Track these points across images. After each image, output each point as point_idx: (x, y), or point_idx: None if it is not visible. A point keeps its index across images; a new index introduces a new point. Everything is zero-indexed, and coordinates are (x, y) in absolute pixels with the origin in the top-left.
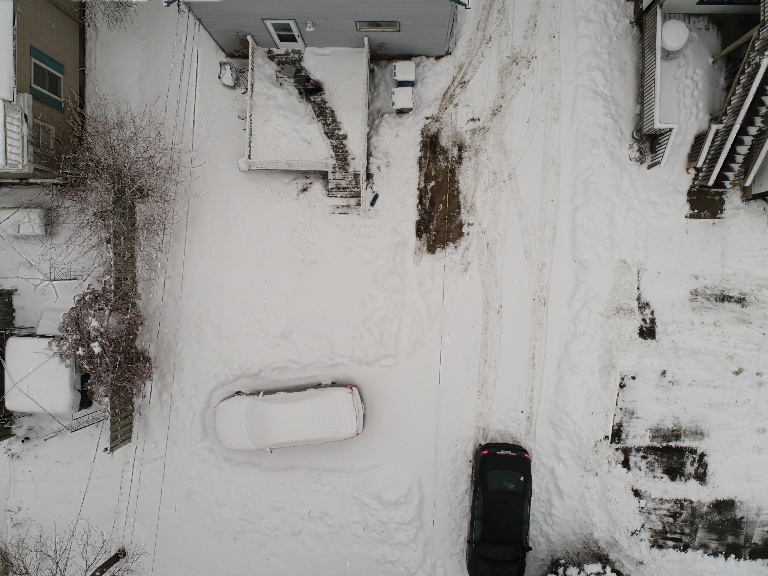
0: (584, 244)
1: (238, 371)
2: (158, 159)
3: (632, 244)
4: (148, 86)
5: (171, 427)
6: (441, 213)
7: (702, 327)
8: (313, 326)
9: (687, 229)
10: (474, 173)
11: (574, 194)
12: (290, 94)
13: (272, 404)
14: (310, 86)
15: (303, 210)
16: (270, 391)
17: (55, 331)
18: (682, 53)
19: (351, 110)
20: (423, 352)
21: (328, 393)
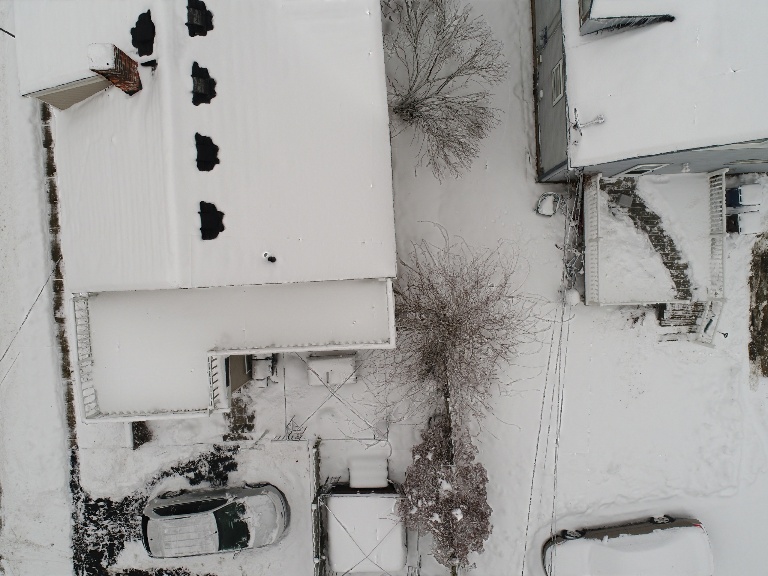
0: None
1: (564, 510)
2: (492, 304)
3: None
4: (450, 217)
5: (494, 571)
6: None
7: None
8: (643, 459)
9: None
10: None
11: None
12: (626, 225)
13: (626, 552)
14: (645, 215)
15: (629, 340)
16: (607, 532)
17: (372, 483)
18: None
19: (696, 240)
20: (764, 480)
21: (681, 535)
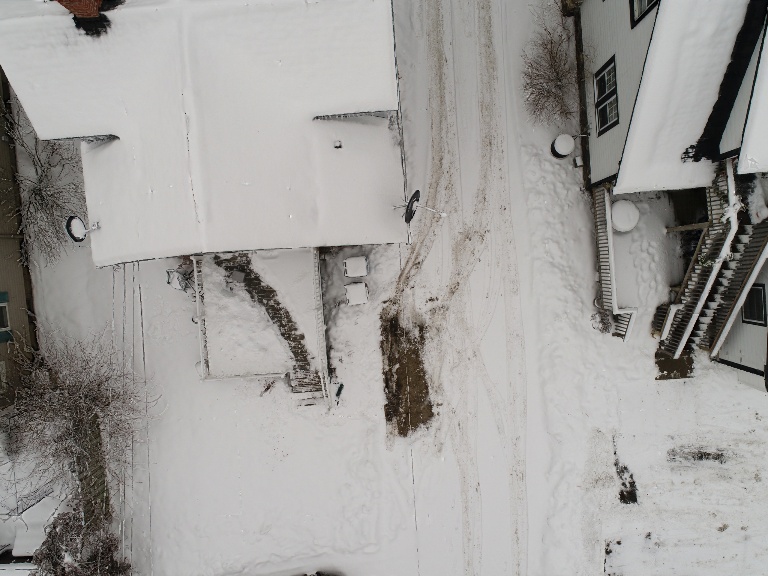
0: (556, 418)
1: (221, 570)
2: (114, 380)
3: (604, 412)
4: (97, 292)
5: None
6: (409, 395)
7: (683, 487)
8: (292, 519)
9: (658, 390)
10: (438, 353)
11: (541, 367)
12: (242, 300)
13: None
14: (261, 288)
15: (269, 406)
16: None
17: None
18: None
19: (305, 312)
20: (405, 536)
21: None
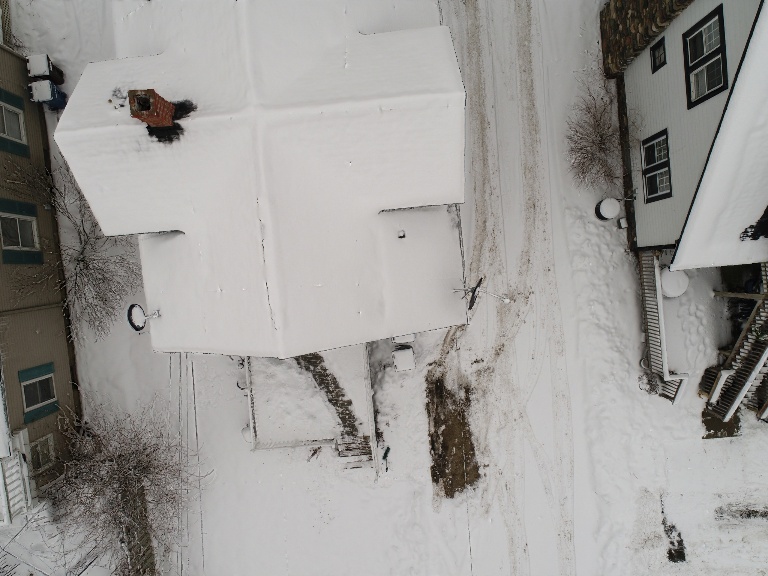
0: (604, 479)
1: None
2: None
3: (652, 472)
4: (141, 357)
5: None
6: (455, 456)
7: (731, 545)
8: None
9: (705, 449)
10: (484, 414)
11: (588, 427)
12: (289, 367)
13: None
14: (308, 355)
15: (315, 469)
16: None
17: None
18: None
19: (353, 379)
20: None
21: None
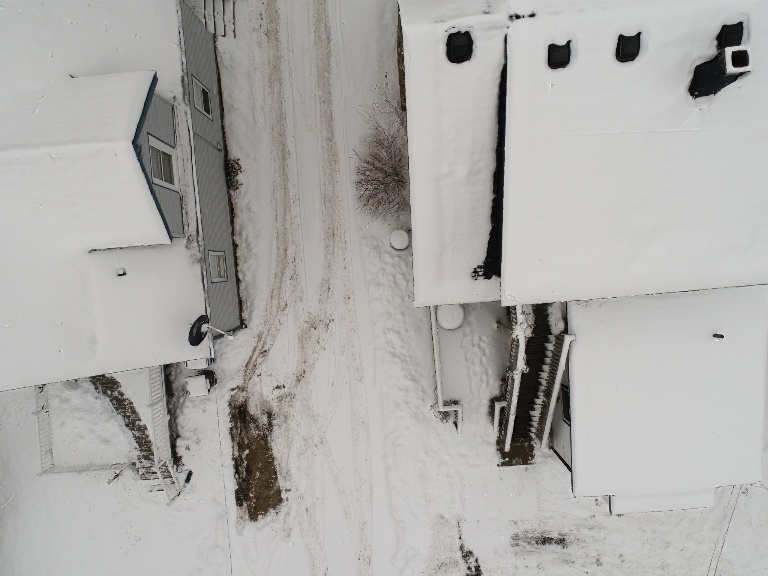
0: (399, 505)
1: None
2: None
3: (447, 498)
4: None
5: None
6: (259, 480)
7: (526, 571)
8: None
9: (501, 476)
10: (286, 440)
11: (385, 454)
12: (85, 391)
13: None
14: (105, 380)
15: (120, 491)
16: None
17: None
18: (466, 321)
19: (147, 404)
20: None
21: None
